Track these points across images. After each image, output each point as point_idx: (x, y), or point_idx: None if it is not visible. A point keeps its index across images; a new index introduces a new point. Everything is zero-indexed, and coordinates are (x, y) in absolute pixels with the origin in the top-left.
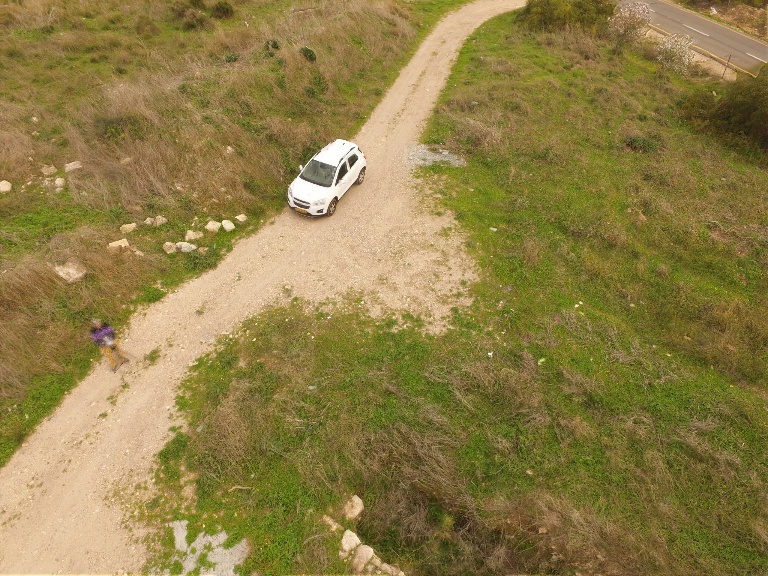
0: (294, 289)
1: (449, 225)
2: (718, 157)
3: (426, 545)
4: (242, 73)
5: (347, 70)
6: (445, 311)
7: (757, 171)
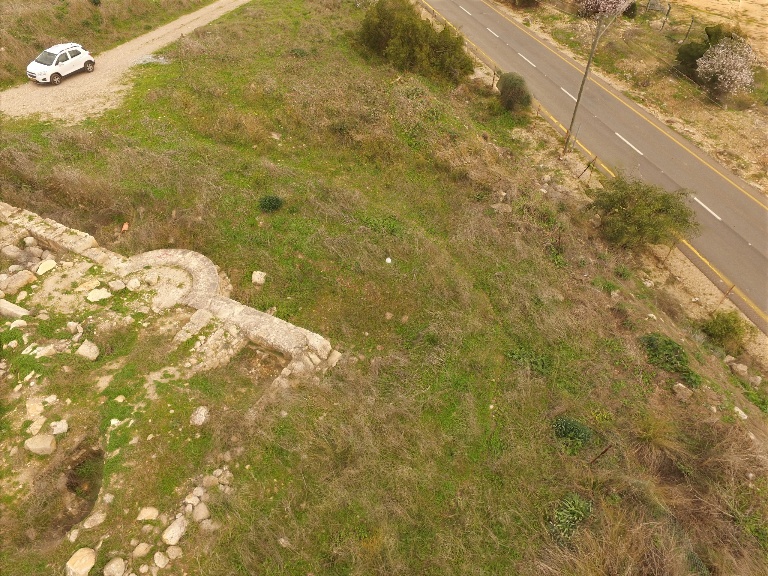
0: (5, 112)
1: (125, 89)
2: (347, 61)
3: (5, 189)
4: (29, 8)
5: (129, 13)
6: (83, 119)
7: (367, 68)
